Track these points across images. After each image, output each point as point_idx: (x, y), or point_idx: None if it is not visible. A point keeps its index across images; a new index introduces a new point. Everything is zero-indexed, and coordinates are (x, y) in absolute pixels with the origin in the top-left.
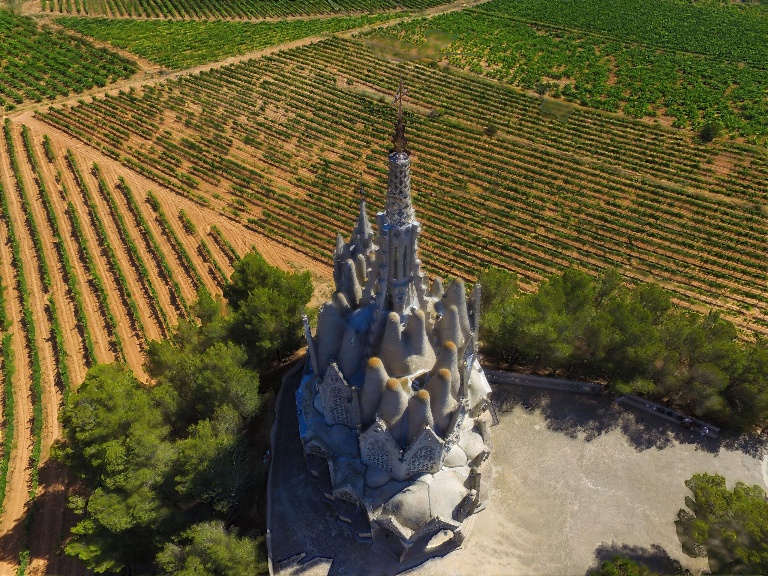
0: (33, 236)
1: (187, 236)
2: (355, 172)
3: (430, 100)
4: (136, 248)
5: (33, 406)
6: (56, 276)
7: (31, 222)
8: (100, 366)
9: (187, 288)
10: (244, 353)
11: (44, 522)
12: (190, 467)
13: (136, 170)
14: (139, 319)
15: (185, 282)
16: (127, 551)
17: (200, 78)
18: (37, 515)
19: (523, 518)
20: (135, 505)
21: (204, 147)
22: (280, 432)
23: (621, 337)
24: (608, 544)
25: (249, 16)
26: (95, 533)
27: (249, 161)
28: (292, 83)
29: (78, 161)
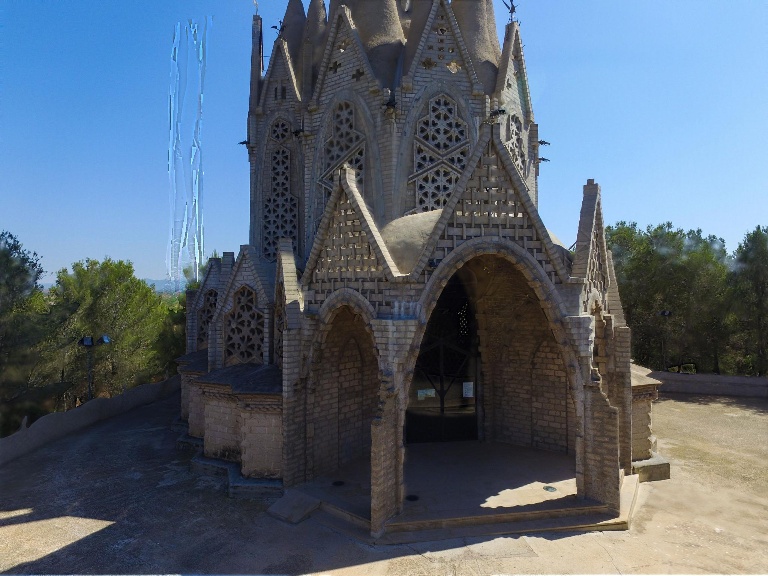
0: None
1: None
2: None
3: None
4: None
5: None
6: None
7: None
8: None
9: None
10: None
11: None
12: None
13: None
14: None
15: None
16: None
17: None
18: None
19: None
20: None
21: None
22: (156, 401)
23: None
24: None
25: None
26: None
27: None
28: None
29: None
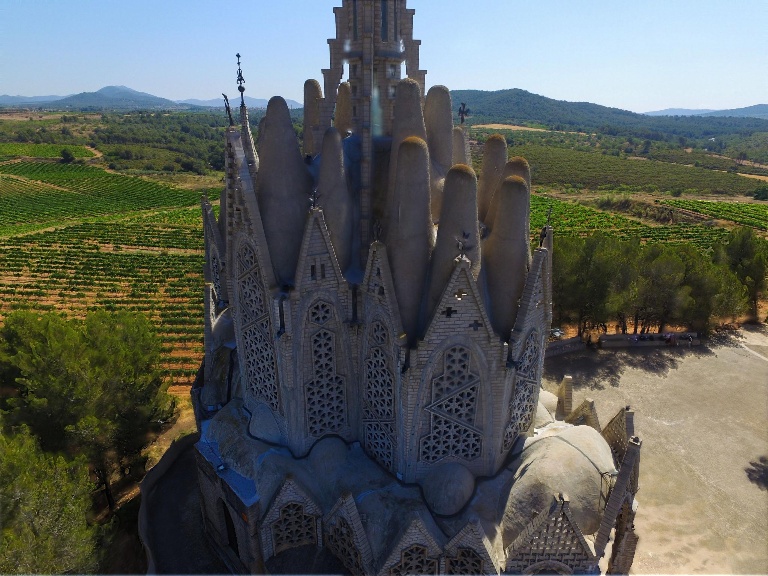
0: None
1: None
2: (155, 303)
3: None
4: None
5: None
6: None
7: None
8: None
9: None
10: None
11: None
12: None
13: None
14: None
15: None
16: None
17: None
18: None
19: (651, 492)
20: None
21: None
22: None
23: None
24: (752, 470)
25: None
26: None
27: None
28: None
29: None
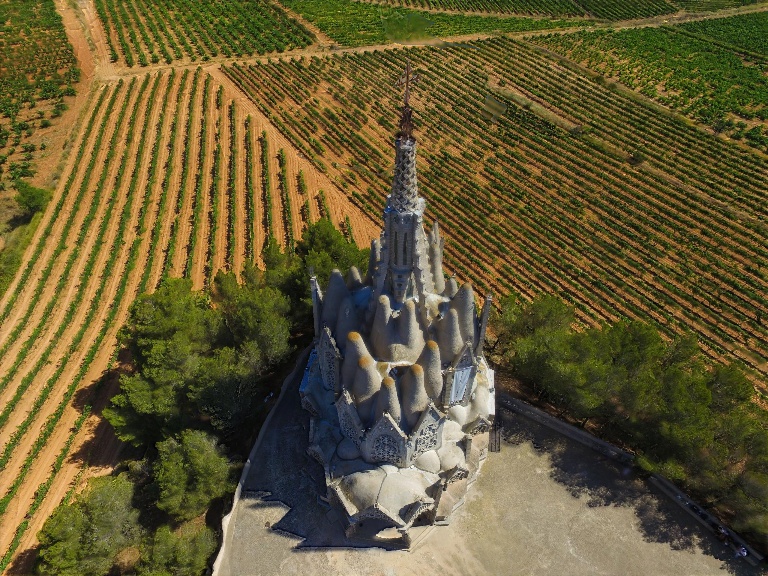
0: (184, 166)
1: (297, 194)
2: (470, 171)
3: (580, 115)
4: (253, 194)
5: (134, 299)
6: (188, 202)
7: (186, 154)
8: (177, 279)
9: (280, 239)
10: (288, 304)
11: (110, 390)
12: (202, 381)
13: (279, 128)
14: (233, 254)
15: (280, 233)
16: (147, 433)
17: (362, 57)
18: (107, 383)
19: (483, 551)
20: (158, 397)
21: (342, 120)
22: (294, 383)
23: (662, 408)
24: None
25: (431, 6)
26: (126, 408)
27: (376, 140)
28: (444, 75)
29: (238, 112)
